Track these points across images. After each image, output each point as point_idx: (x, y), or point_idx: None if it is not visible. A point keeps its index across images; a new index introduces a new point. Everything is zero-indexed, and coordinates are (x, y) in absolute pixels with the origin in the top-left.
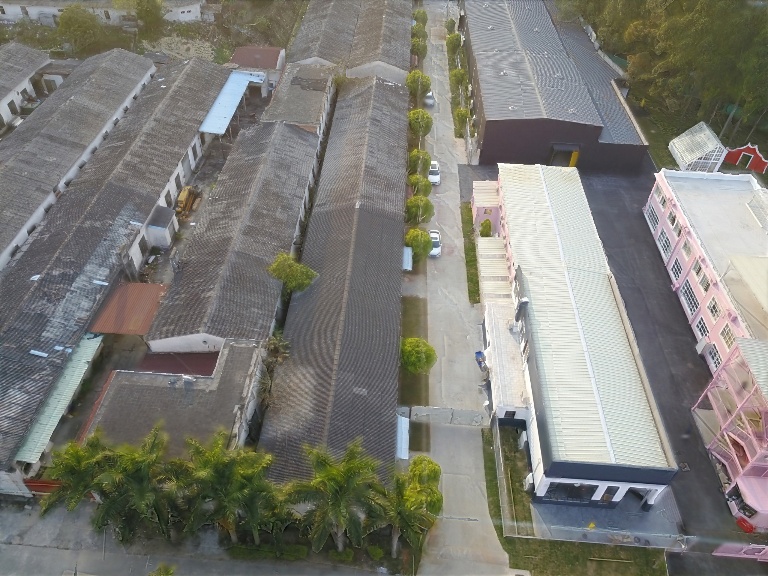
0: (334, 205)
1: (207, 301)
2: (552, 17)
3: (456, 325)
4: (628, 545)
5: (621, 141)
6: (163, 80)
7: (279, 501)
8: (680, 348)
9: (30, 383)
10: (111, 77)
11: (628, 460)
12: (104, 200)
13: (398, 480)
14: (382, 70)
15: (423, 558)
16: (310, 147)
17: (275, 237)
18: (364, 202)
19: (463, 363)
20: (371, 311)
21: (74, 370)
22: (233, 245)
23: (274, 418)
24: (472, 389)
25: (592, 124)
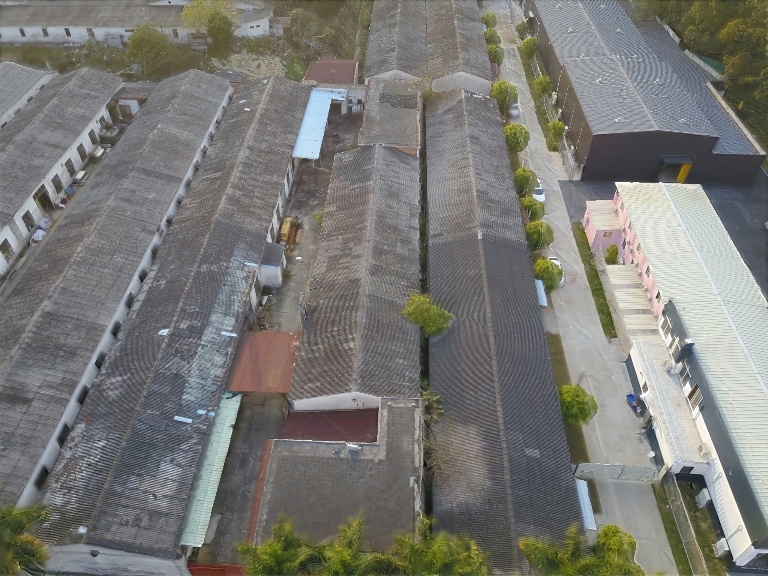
0: (452, 236)
1: (351, 354)
2: None
3: (597, 364)
4: None
5: (735, 151)
6: (245, 102)
7: None
8: None
9: (180, 454)
10: (193, 101)
11: None
12: (215, 240)
13: None
14: (464, 81)
15: None
16: (413, 171)
17: (401, 275)
18: (485, 232)
19: (614, 408)
20: (521, 357)
21: (220, 435)
22: (363, 288)
23: (444, 486)
24: (631, 438)
25: (708, 135)
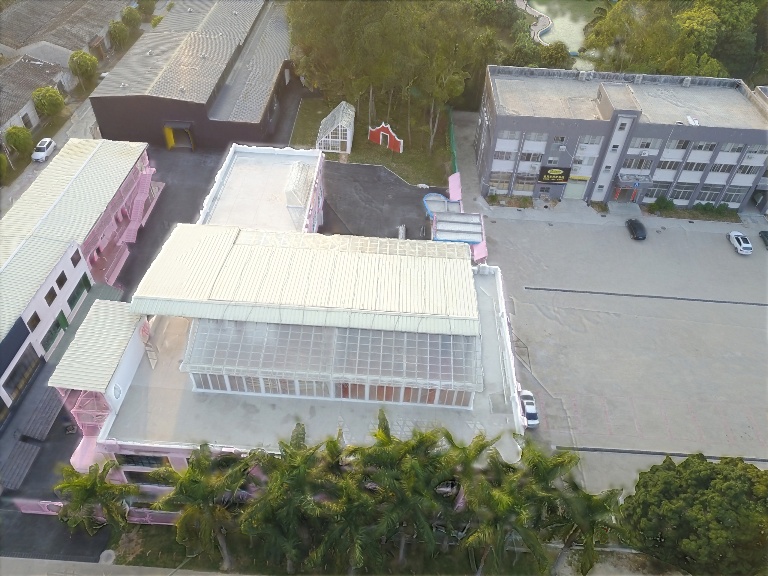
0: None
1: None
2: None
3: None
4: None
5: (236, 119)
6: None
7: None
8: None
9: None
10: None
11: None
12: None
13: None
14: (51, 50)
15: None
16: None
17: None
18: None
19: None
20: None
21: None
22: None
23: None
24: None
25: (193, 101)
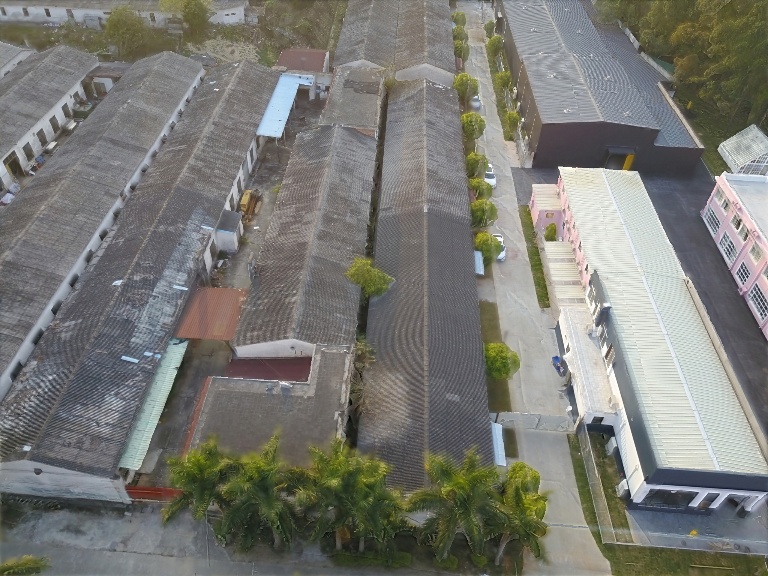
0: (401, 209)
1: (292, 306)
2: (591, 19)
3: (529, 330)
4: (728, 552)
5: (676, 144)
6: (215, 83)
7: (393, 509)
8: (753, 353)
9: (125, 389)
10: (164, 80)
11: (732, 467)
12: (174, 204)
13: (497, 487)
14: (429, 73)
15: (525, 565)
16: (369, 150)
17: (348, 241)
18: (431, 206)
19: (540, 368)
20: (452, 316)
21: (164, 376)
22: (310, 250)
23: (369, 424)
24: (553, 394)
25: (649, 127)
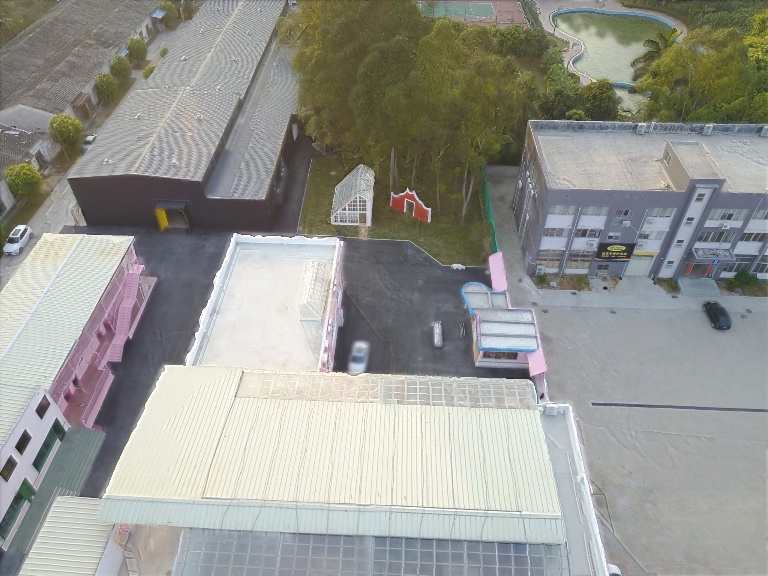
0: None
1: None
2: None
3: None
4: None
5: (238, 195)
6: None
7: None
8: None
9: None
10: None
11: None
12: None
13: None
14: (30, 114)
15: None
16: None
17: None
18: None
19: None
20: None
21: None
22: None
23: None
24: None
25: (187, 179)
